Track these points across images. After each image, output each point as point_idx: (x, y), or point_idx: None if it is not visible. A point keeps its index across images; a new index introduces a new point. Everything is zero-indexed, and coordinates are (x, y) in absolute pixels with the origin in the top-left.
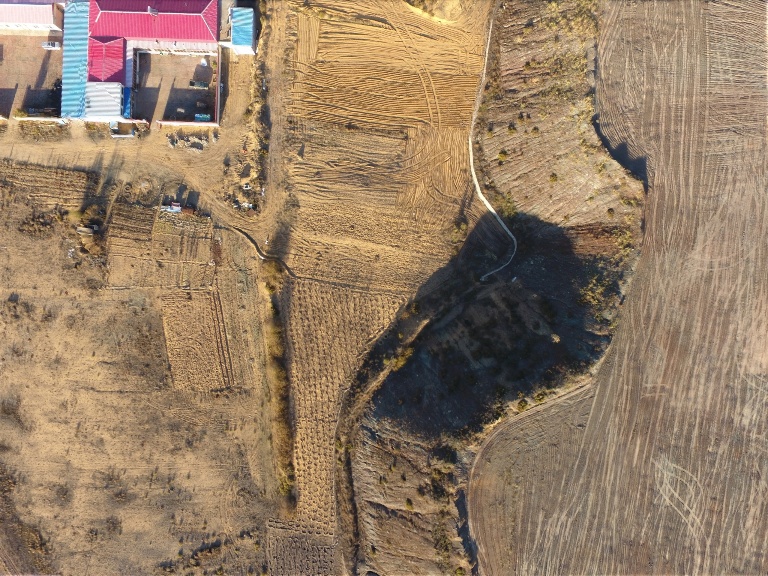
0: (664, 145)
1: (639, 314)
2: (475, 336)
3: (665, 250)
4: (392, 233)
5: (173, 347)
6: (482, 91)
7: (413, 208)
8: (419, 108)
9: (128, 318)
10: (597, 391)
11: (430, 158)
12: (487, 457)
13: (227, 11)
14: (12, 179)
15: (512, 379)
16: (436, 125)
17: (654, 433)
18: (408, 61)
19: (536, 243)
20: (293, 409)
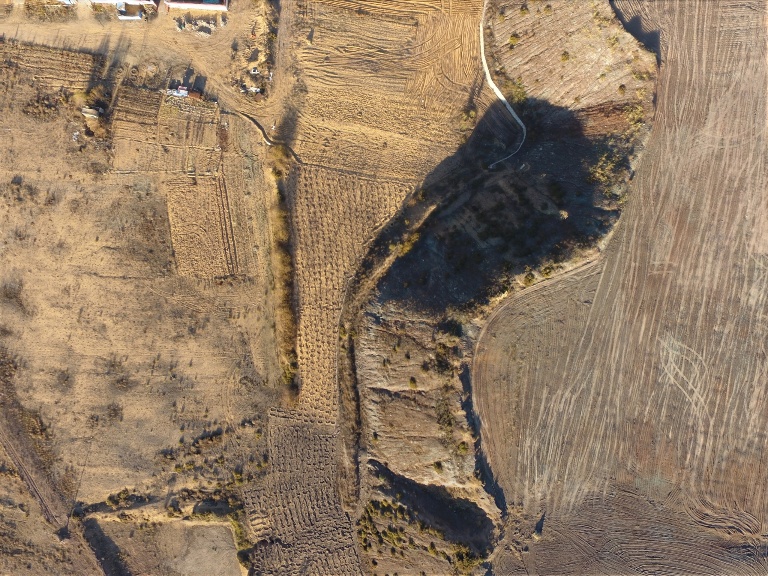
0: (678, 19)
1: (648, 191)
2: (482, 219)
3: (676, 126)
4: (400, 120)
5: (177, 233)
6: None
7: (422, 96)
8: None
9: (132, 203)
10: (604, 267)
11: (440, 45)
12: (492, 332)
13: None
14: (17, 60)
15: (519, 255)
16: (447, 11)
17: (660, 311)
18: None
19: (545, 130)
20: (297, 296)
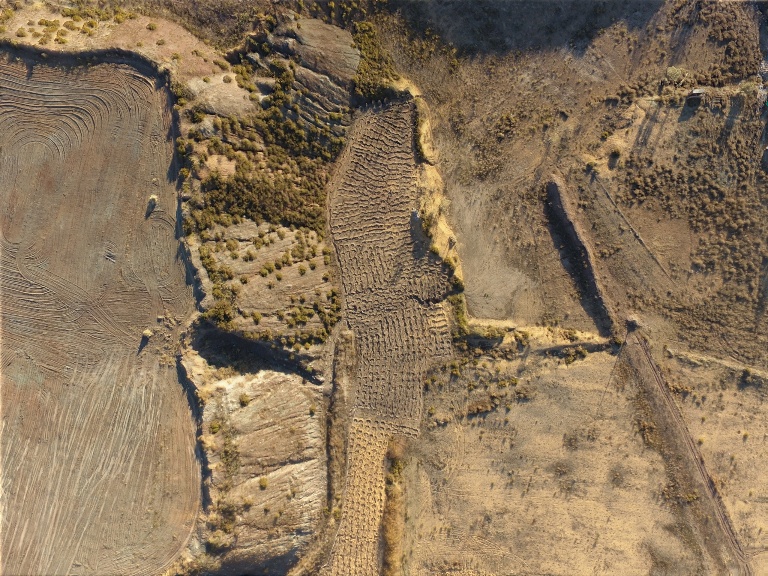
0: None
1: None
2: None
3: None
4: None
5: None
6: None
7: None
8: None
9: None
10: None
11: None
12: (176, 542)
13: None
14: None
15: None
16: None
17: (4, 552)
18: None
19: None
20: None
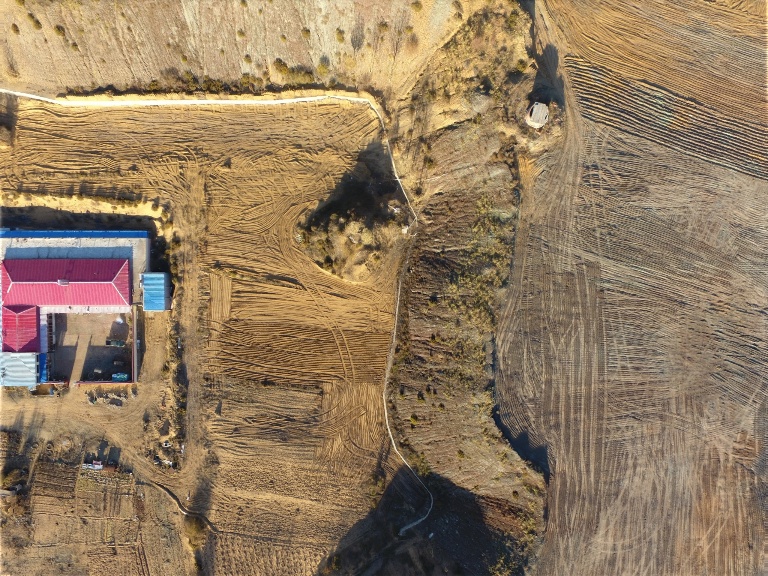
0: (564, 433)
1: None
2: None
3: (568, 535)
4: (311, 487)
5: None
6: (393, 352)
7: (331, 461)
8: (333, 364)
9: (55, 574)
10: None
11: (346, 412)
12: None
13: (138, 275)
14: None
15: None
16: (351, 380)
17: None
18: (320, 319)
19: (451, 501)
20: None
